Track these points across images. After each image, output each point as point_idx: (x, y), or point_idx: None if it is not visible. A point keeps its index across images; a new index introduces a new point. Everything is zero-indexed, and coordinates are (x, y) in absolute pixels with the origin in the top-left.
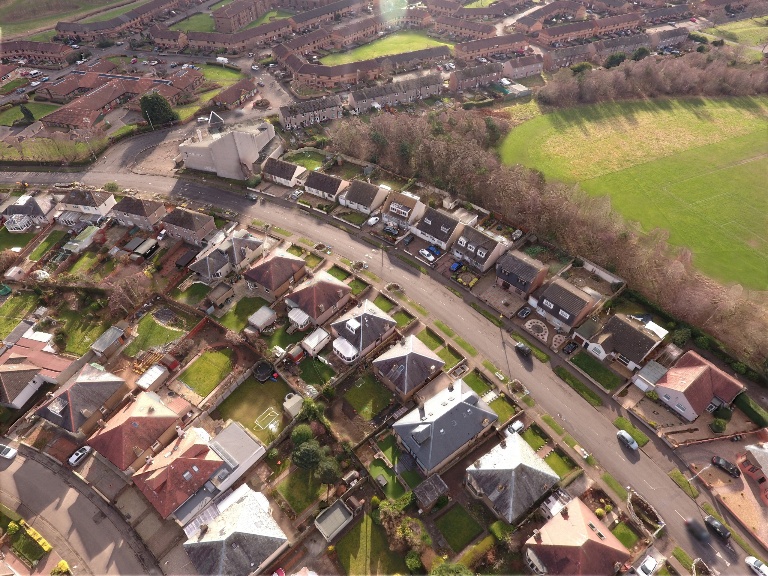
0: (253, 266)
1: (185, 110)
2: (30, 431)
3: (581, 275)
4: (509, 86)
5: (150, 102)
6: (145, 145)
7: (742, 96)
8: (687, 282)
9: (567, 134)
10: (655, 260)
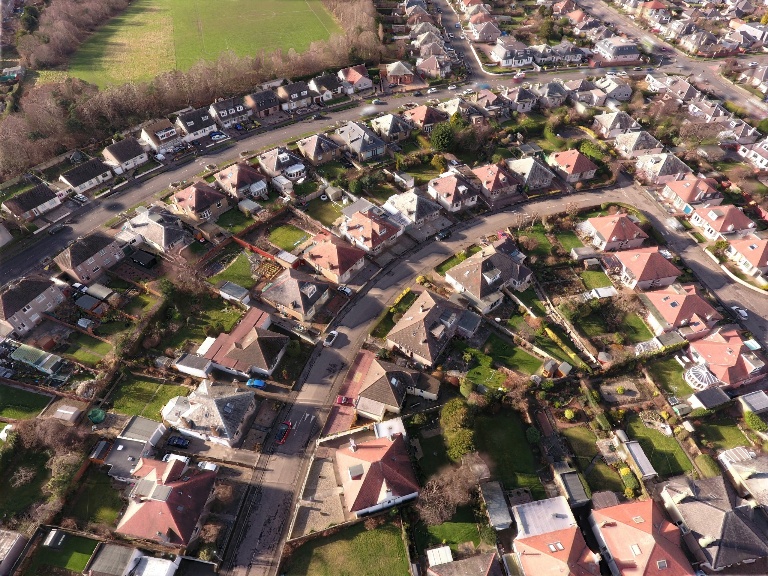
0: None
1: None
2: (314, 331)
3: None
4: (2, 73)
5: None
6: None
7: (127, 8)
8: (301, 55)
9: (111, 68)
10: (269, 70)
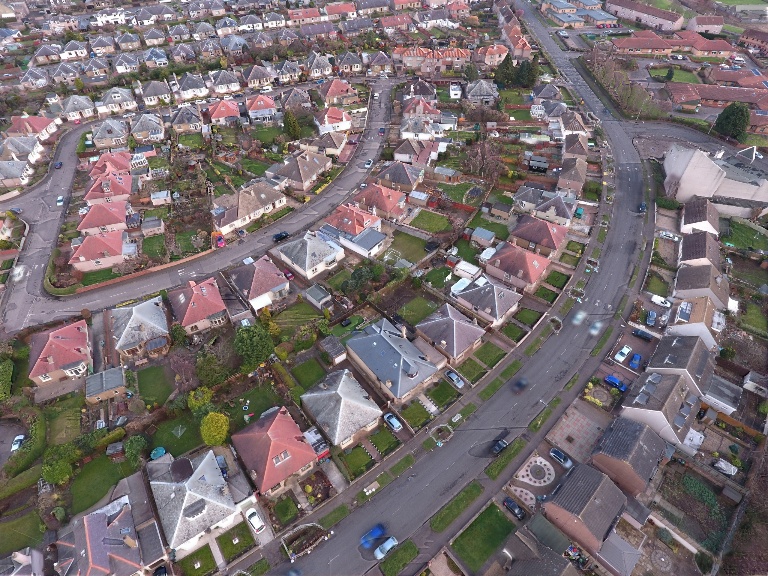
0: (535, 217)
1: (766, 142)
2: None
3: (681, 568)
4: None
5: (732, 110)
6: (680, 136)
7: None
8: None
9: None
10: None
